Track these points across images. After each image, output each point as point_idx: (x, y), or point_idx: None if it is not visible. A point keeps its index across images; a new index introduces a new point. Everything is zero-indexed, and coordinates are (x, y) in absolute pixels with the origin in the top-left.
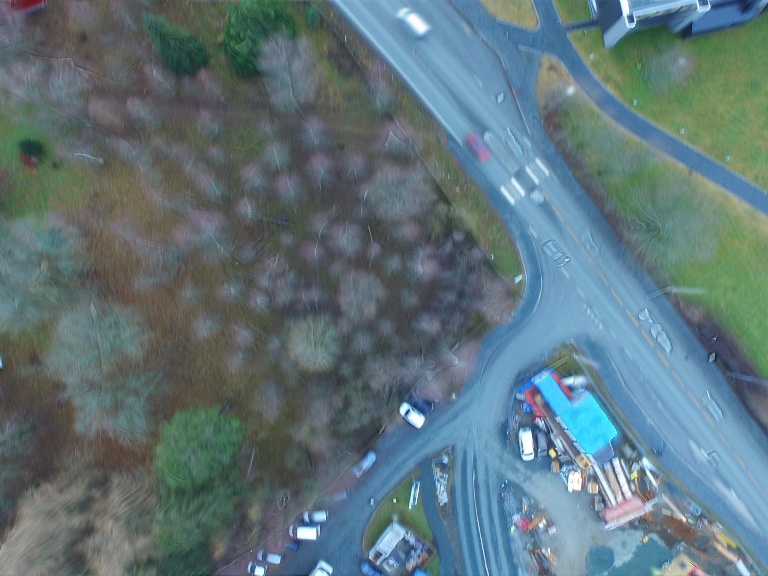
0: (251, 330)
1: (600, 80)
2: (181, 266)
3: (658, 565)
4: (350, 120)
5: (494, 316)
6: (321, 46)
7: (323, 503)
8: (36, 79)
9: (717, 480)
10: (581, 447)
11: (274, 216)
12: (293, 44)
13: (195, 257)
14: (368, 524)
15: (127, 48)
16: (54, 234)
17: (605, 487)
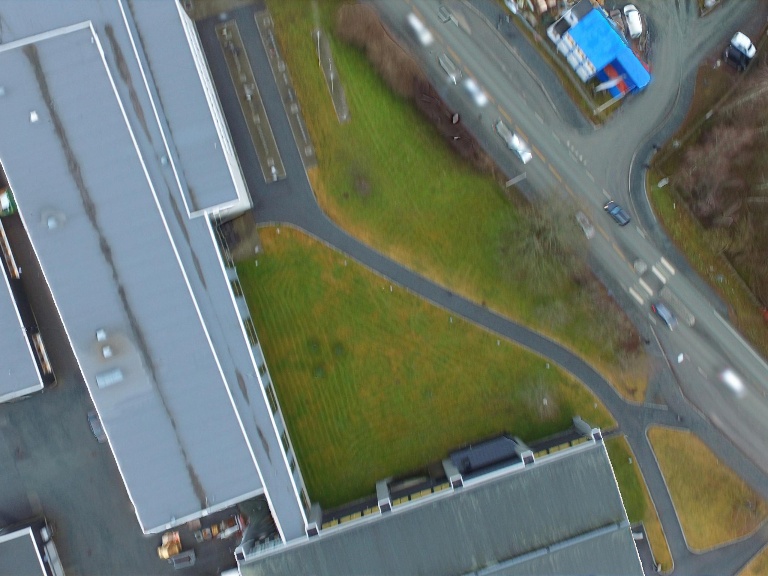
0: None
1: (583, 385)
2: None
3: None
4: None
5: None
6: None
7: None
8: None
9: None
10: None
11: None
12: None
13: None
14: None
15: None
16: None
17: None
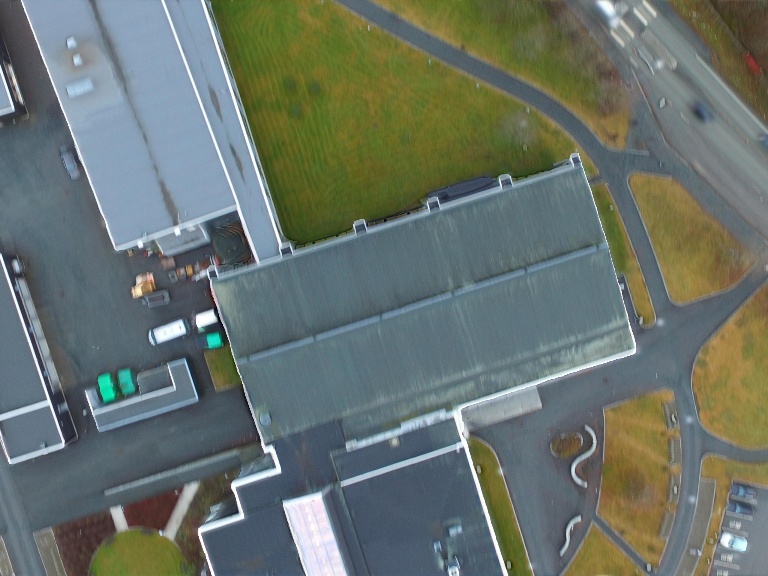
0: None
1: (563, 131)
2: None
3: None
4: None
5: None
6: None
7: None
8: None
9: None
10: None
11: None
12: None
13: None
14: None
15: None
16: None
17: None
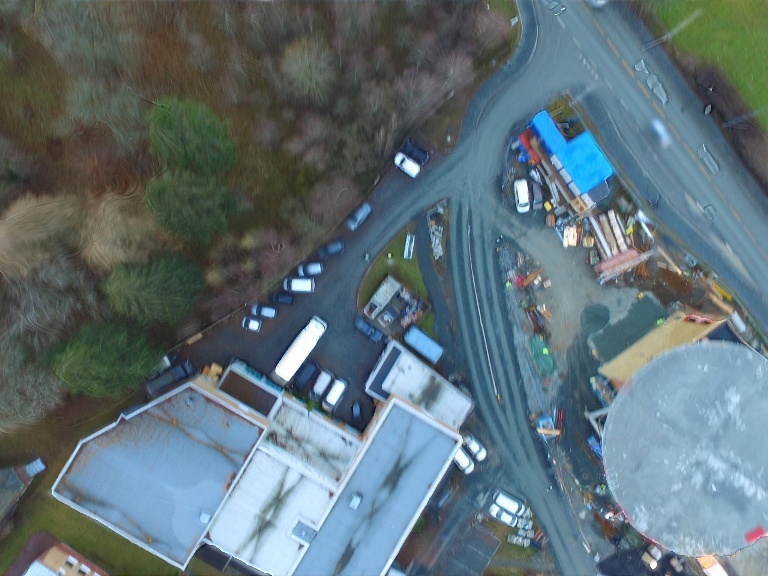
0: (245, 62)
1: None
2: (176, 12)
3: (653, 320)
4: None
5: (490, 61)
6: None
7: (318, 257)
8: None
9: (713, 234)
10: (576, 186)
11: None
12: None
13: (190, 2)
14: (363, 280)
15: None
16: None
17: (600, 238)
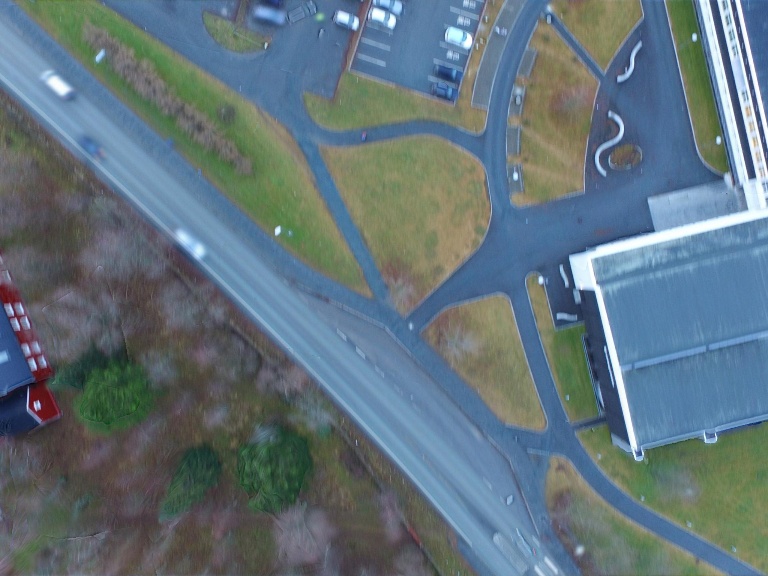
0: None
1: (608, 476)
2: None
3: None
4: (361, 519)
5: None
6: (332, 450)
7: None
8: (55, 573)
9: None
10: None
11: None
12: (305, 457)
13: None
14: None
15: (141, 459)
16: None
17: None
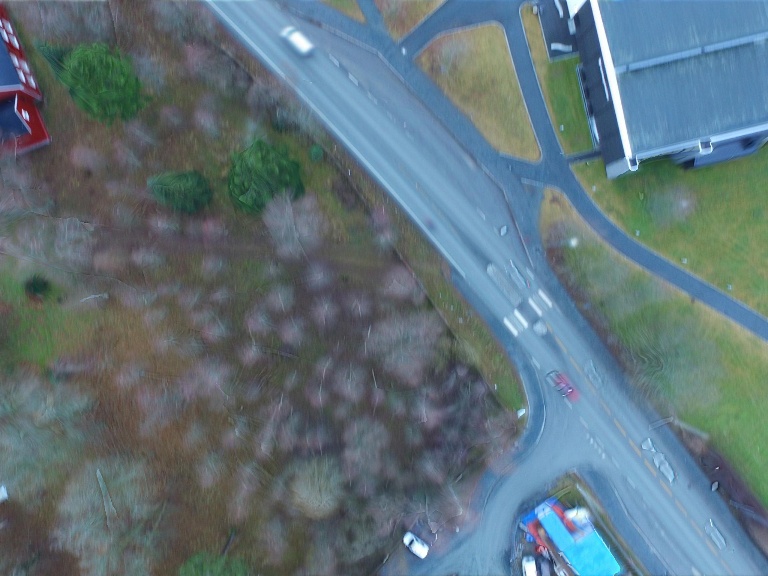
0: (256, 469)
1: (603, 210)
2: (186, 398)
3: None
4: (354, 252)
5: (497, 448)
6: (325, 180)
7: None
8: (42, 243)
9: None
10: None
11: (278, 348)
12: (297, 181)
13: (199, 389)
14: None
15: (131, 184)
16: (59, 369)
17: None
